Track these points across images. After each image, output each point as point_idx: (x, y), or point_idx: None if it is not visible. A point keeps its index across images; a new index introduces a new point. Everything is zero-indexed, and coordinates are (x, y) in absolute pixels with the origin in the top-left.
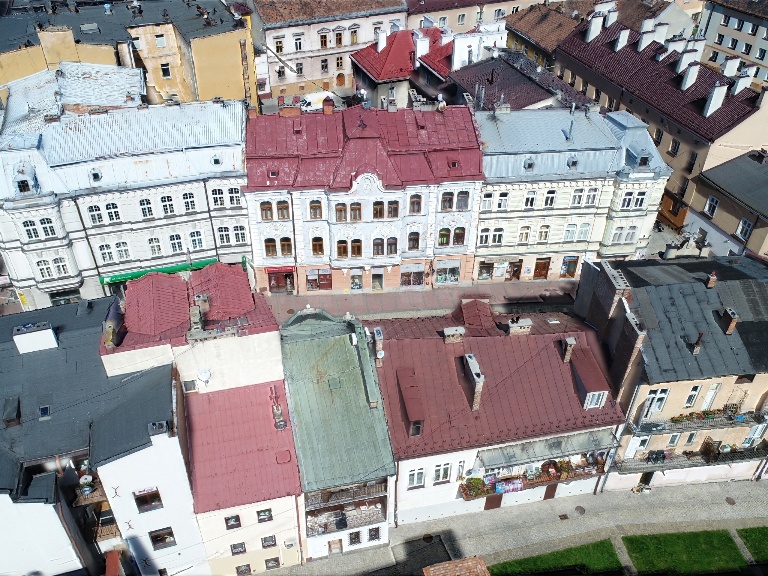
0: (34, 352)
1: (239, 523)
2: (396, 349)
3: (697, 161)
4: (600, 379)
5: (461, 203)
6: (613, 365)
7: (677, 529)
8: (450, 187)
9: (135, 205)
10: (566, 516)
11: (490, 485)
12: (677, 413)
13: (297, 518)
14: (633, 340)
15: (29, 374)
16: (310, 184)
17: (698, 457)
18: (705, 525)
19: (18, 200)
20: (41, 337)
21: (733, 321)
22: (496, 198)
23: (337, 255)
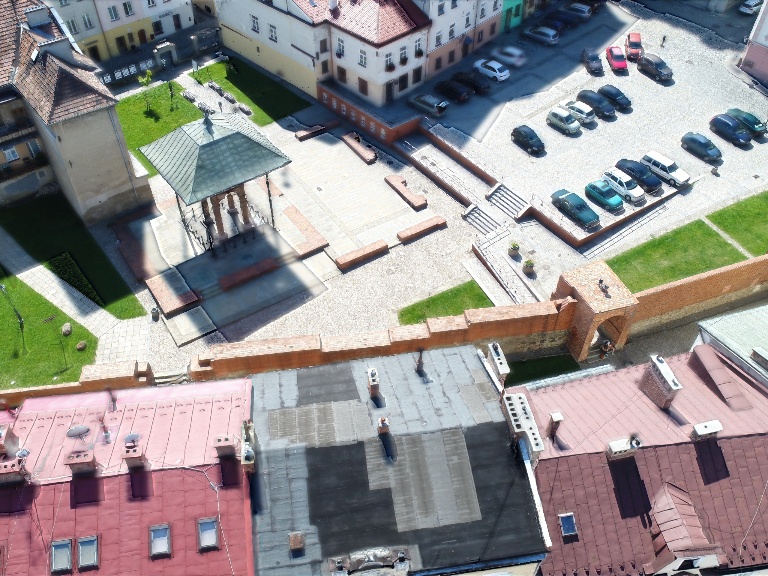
0: None
1: None
2: None
3: None
4: None
5: None
6: None
7: None
8: None
9: None
10: None
11: None
12: None
13: None
14: None
15: None
16: None
17: None
18: None
19: None
20: None
21: None
22: None
23: None
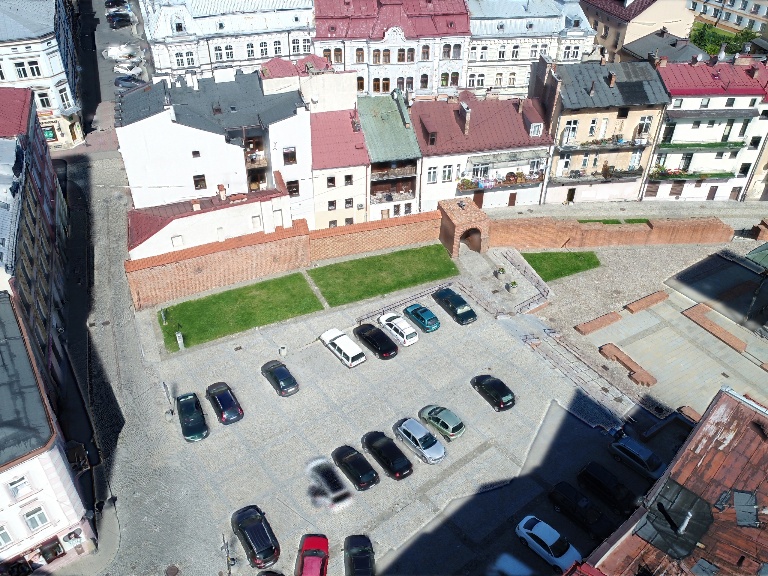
0: (223, 83)
1: (334, 184)
2: (419, 106)
3: (620, 38)
4: (539, 118)
5: (456, 54)
6: (547, 112)
7: (588, 218)
8: (449, 41)
9: (244, 47)
10: (522, 213)
11: (475, 184)
12: (585, 140)
13: (366, 186)
14: (556, 87)
15: (222, 92)
16: (357, 36)
17: (600, 175)
18: (605, 217)
19: (175, 37)
20: (228, 73)
21: (613, 77)
22: (479, 51)
23: (373, 90)
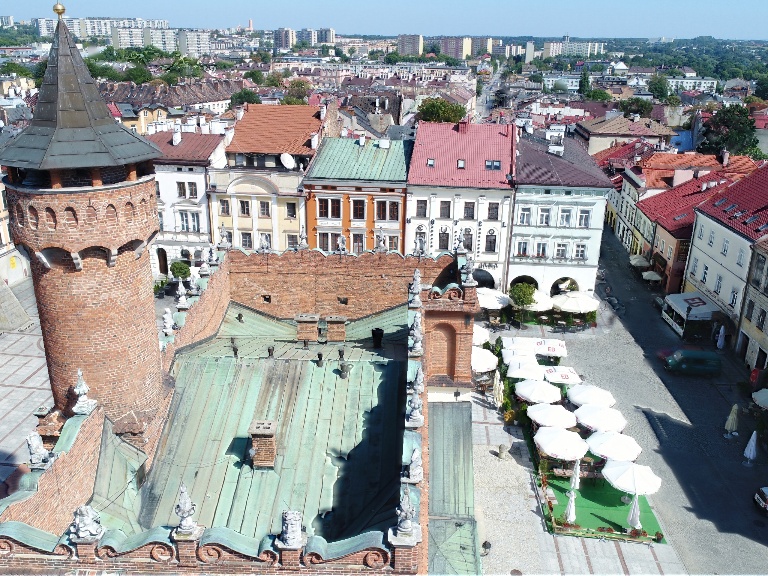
0: None
1: None
2: None
3: None
4: None
5: None
6: None
7: None
8: None
9: None
10: None
11: None
12: None
13: None
14: (4, 114)
15: None
16: None
17: None
18: None
19: None
20: None
21: None
22: None
23: None
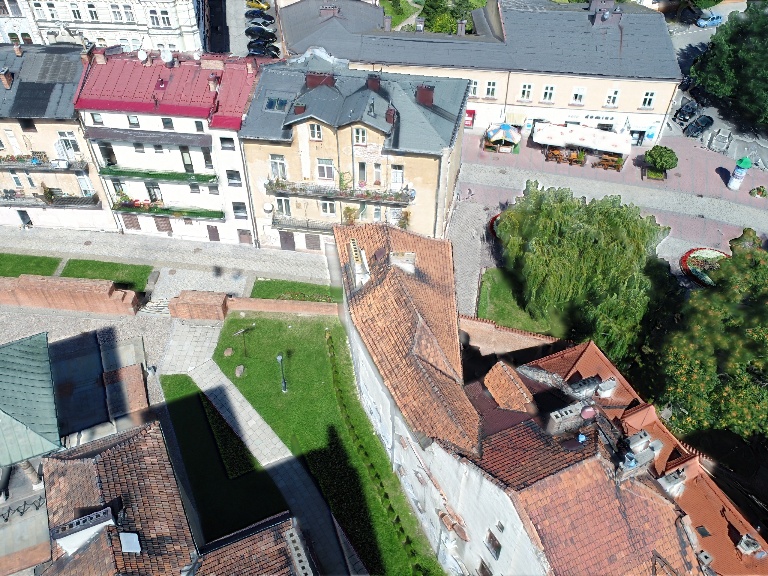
0: None
1: None
2: None
3: None
4: None
5: (16, 10)
6: None
7: (25, 253)
8: None
9: None
10: None
11: None
12: None
13: None
14: None
15: None
16: None
17: None
18: (49, 253)
19: None
20: None
21: (1, 77)
22: (45, 8)
23: None
